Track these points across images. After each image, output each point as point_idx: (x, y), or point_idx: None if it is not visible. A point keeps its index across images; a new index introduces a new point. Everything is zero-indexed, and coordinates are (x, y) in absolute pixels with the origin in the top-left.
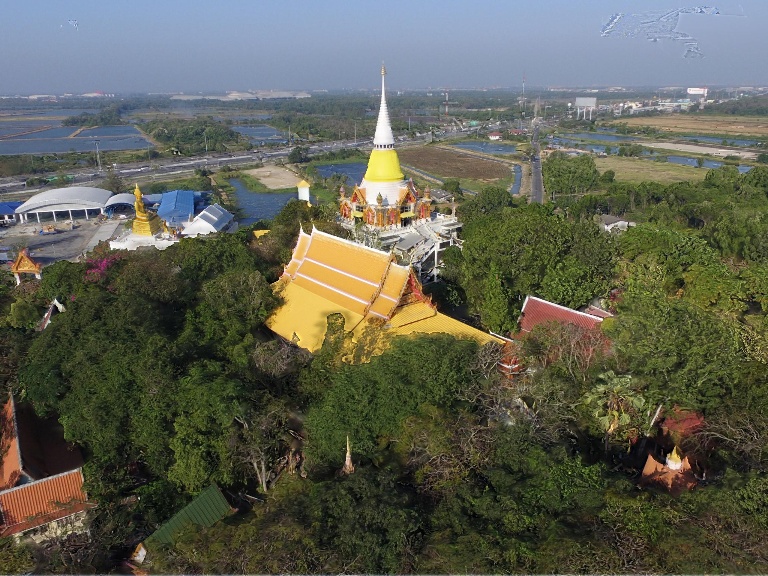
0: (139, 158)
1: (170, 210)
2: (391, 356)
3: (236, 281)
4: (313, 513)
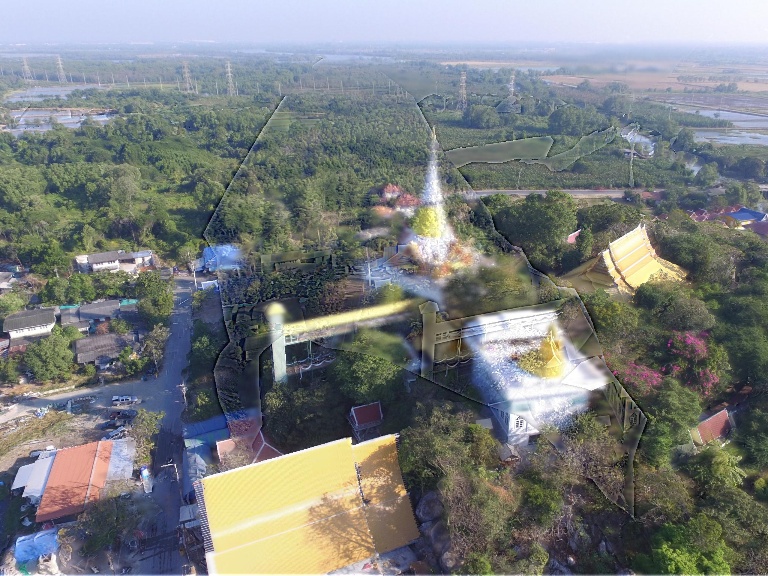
0: None
1: None
2: None
3: (668, 281)
4: None
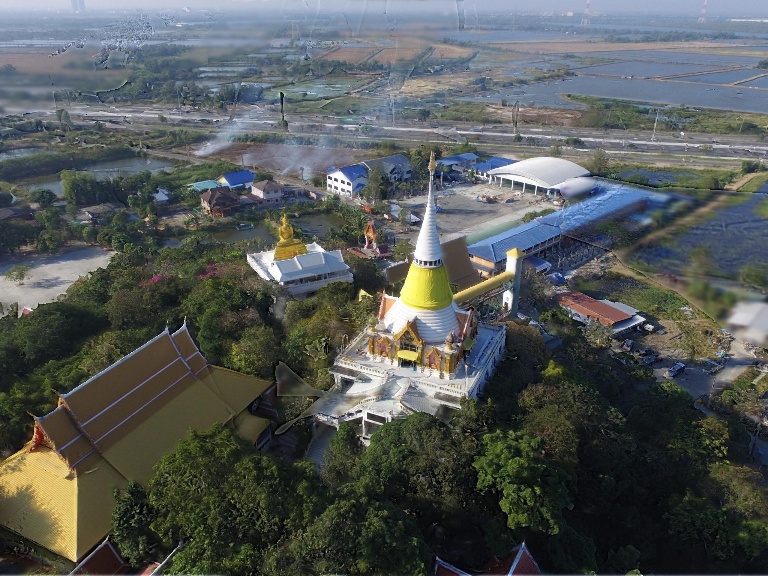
0: (728, 129)
1: None
2: None
3: None
4: None
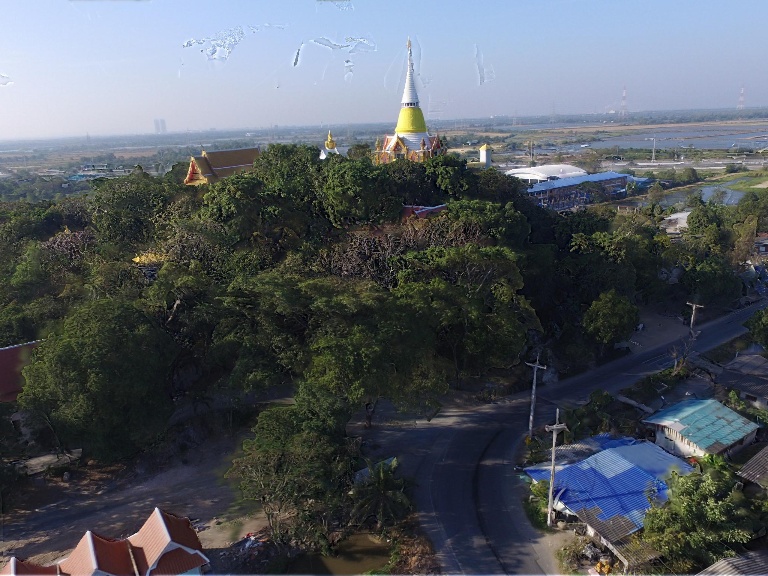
0: None
1: (548, 181)
2: None
3: None
4: None
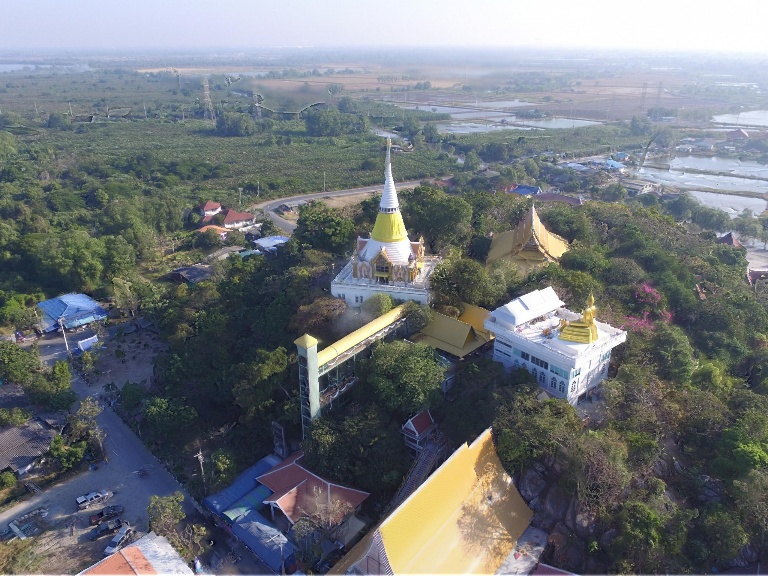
0: None
1: None
2: (572, 216)
3: None
4: (623, 222)
